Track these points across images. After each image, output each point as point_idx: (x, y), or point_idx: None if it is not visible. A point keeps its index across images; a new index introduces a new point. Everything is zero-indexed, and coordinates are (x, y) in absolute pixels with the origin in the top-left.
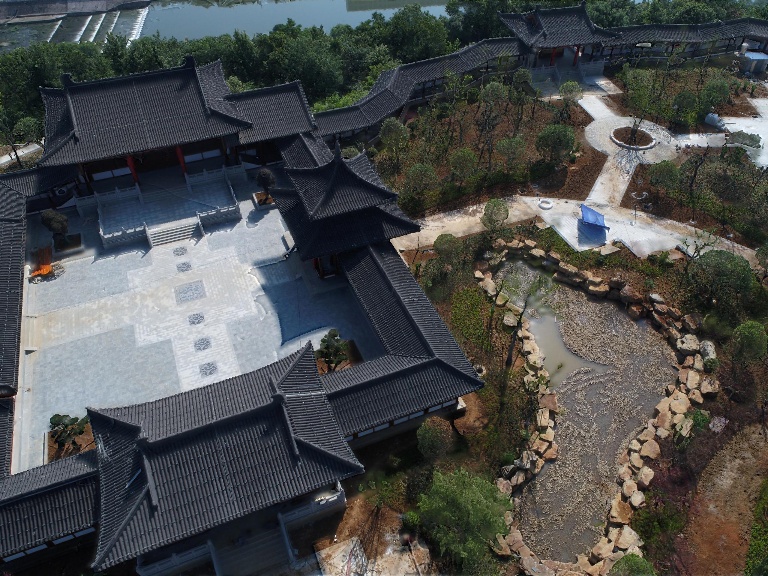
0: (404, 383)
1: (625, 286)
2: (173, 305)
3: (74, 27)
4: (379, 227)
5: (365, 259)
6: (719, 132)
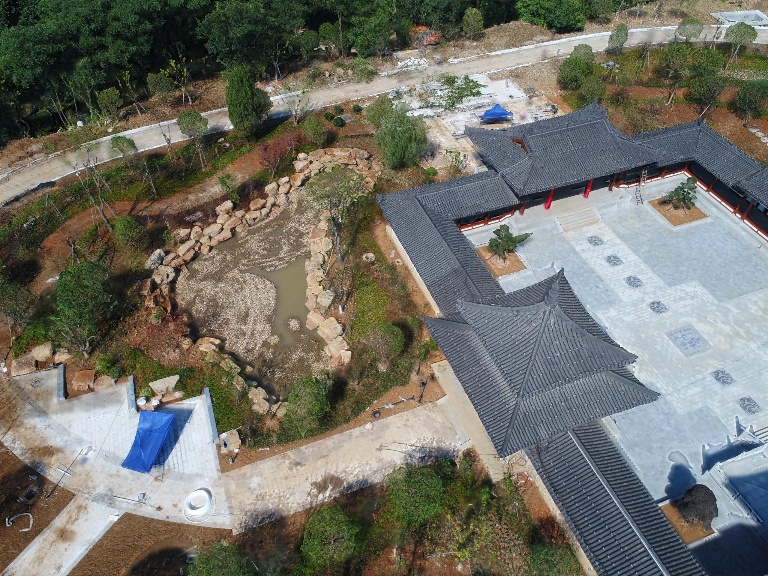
0: None
1: None
2: (695, 324)
3: None
4: None
5: None
6: None
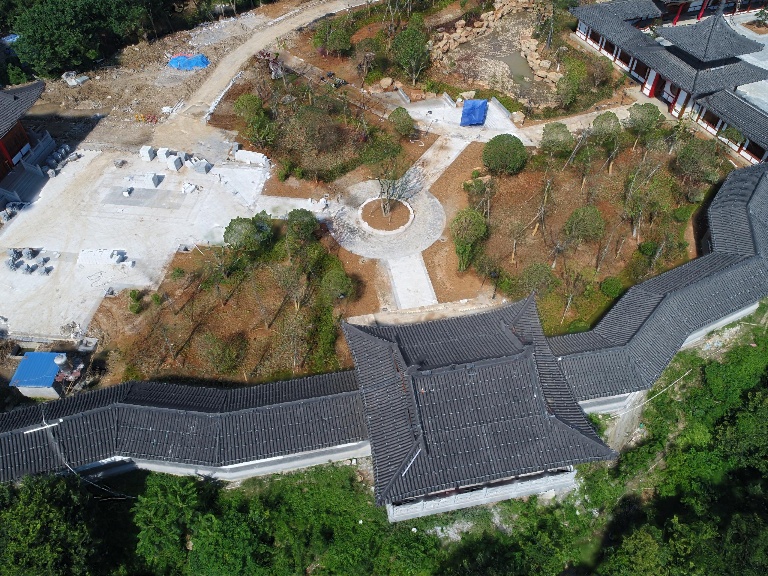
0: None
1: None
2: None
3: None
4: None
5: None
6: None
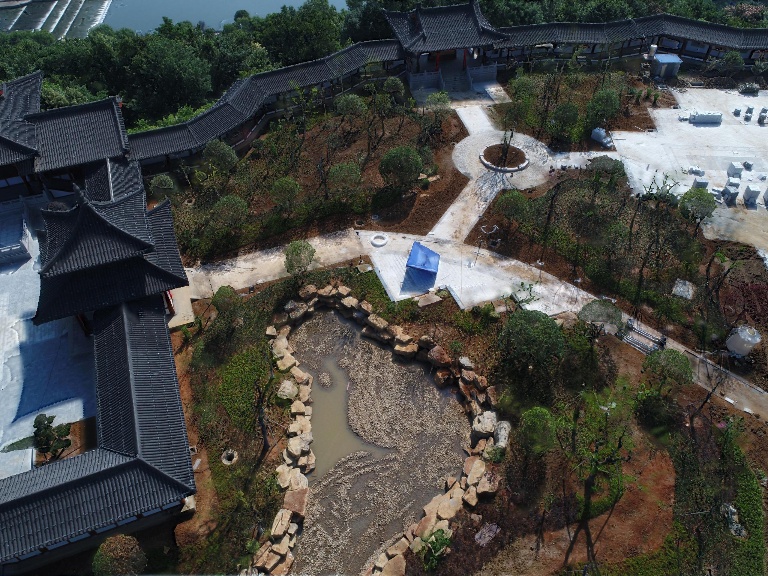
0: (93, 491)
1: (435, 346)
2: None
3: (38, 13)
4: (140, 281)
5: (116, 320)
6: (604, 150)
